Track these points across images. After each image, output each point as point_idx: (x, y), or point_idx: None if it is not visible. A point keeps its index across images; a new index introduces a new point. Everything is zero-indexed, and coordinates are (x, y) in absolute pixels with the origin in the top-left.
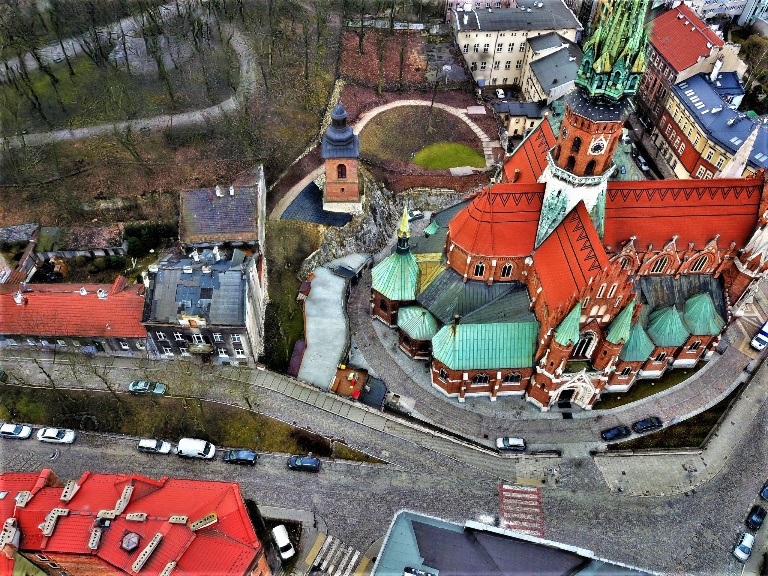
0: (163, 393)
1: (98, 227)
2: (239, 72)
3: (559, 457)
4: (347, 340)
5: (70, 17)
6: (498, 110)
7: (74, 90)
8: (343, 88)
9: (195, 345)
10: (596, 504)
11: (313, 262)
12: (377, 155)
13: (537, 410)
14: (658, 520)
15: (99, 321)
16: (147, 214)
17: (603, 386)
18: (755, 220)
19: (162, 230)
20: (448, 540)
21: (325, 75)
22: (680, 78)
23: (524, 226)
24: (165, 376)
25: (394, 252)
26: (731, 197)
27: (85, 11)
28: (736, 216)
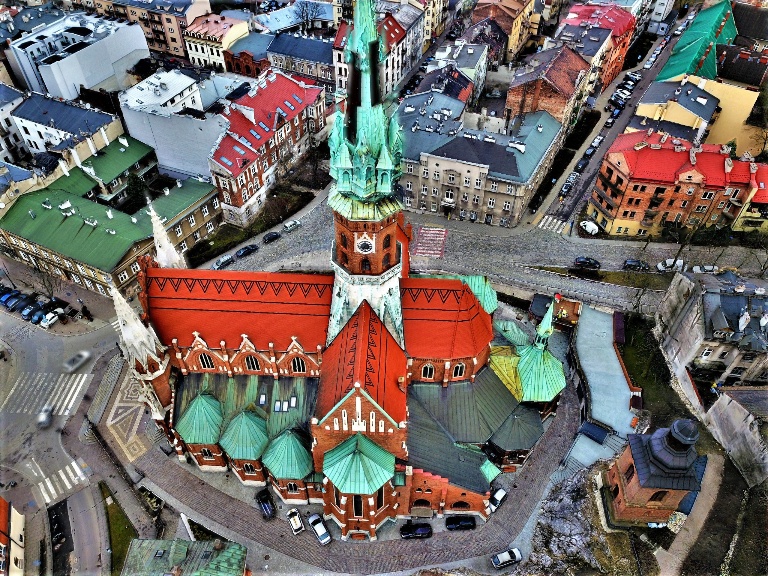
0: None
1: None
2: None
3: None
4: None
5: None
6: None
7: None
8: None
9: None
10: None
11: None
12: None
13: None
14: None
15: None
16: None
17: None
18: None
19: None
20: (498, 167)
21: None
22: None
23: None
24: None
25: None
26: None
27: None
28: None
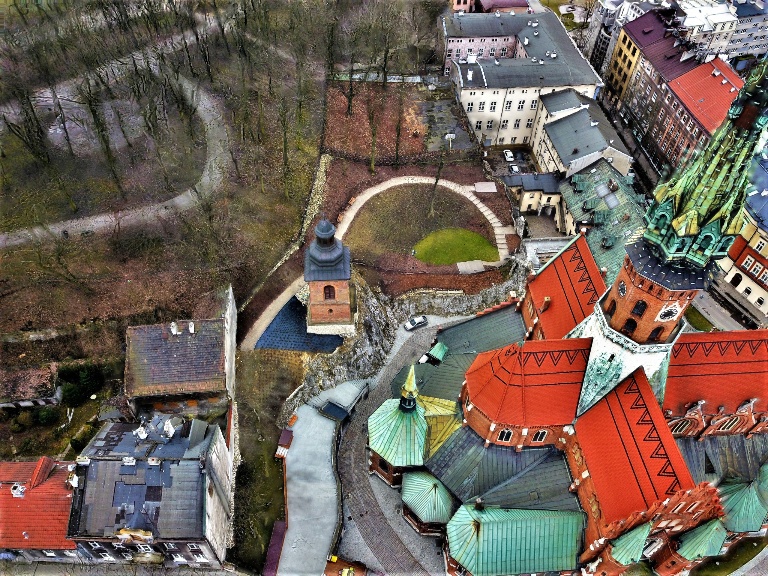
0: None
1: (24, 370)
2: (205, 150)
3: None
4: (339, 517)
5: (6, 77)
6: (509, 183)
7: (3, 179)
8: (330, 165)
9: (141, 553)
10: None
11: (295, 401)
12: (371, 251)
13: None
14: None
15: (13, 527)
16: (87, 351)
17: None
18: None
19: (106, 370)
20: None
21: (308, 149)
22: None
23: (564, 389)
24: None
25: (396, 405)
26: None
27: (24, 70)
28: None
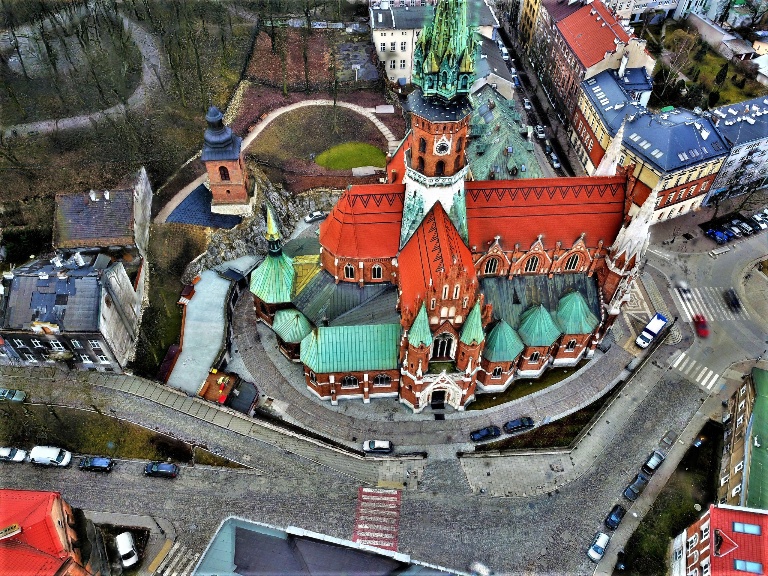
0: (23, 400)
1: None
2: (140, 74)
3: (425, 459)
4: (222, 344)
5: None
6: None
7: None
8: (247, 89)
9: (55, 352)
10: (455, 506)
11: (199, 265)
12: (276, 156)
13: (410, 412)
14: (516, 521)
15: None
16: (27, 219)
17: (474, 387)
18: (621, 218)
19: (43, 235)
20: (268, 546)
21: (230, 76)
22: (589, 74)
23: (387, 227)
24: (28, 383)
25: None
26: (595, 195)
27: None
28: (602, 214)
